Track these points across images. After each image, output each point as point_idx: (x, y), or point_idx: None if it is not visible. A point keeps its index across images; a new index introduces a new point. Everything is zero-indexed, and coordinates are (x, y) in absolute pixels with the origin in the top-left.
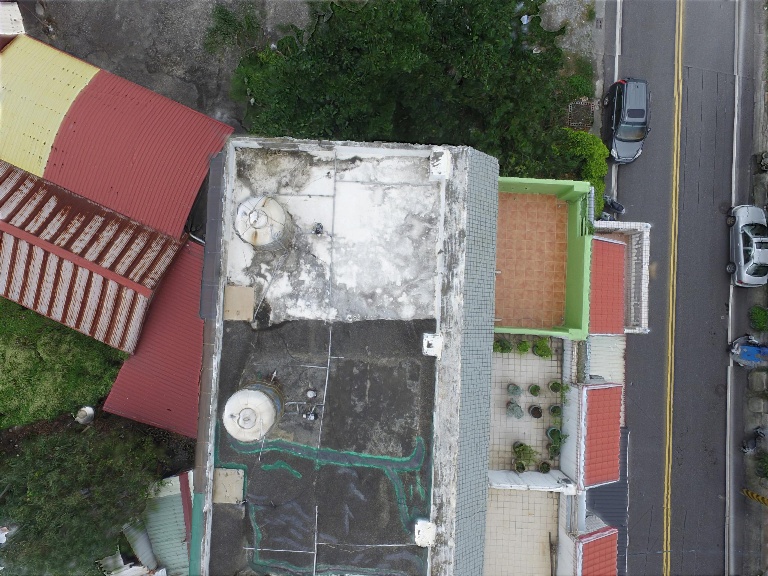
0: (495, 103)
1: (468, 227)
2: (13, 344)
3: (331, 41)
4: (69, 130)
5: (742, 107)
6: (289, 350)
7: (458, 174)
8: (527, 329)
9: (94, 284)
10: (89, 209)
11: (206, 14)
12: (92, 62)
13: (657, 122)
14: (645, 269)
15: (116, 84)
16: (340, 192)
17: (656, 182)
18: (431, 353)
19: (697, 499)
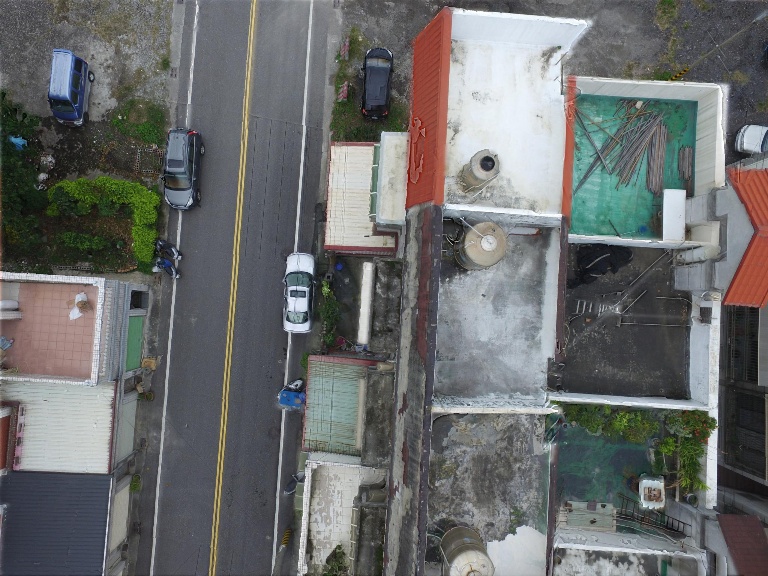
0: None
1: None
2: None
3: None
4: None
5: (309, 156)
6: None
7: None
8: None
9: None
10: None
11: None
12: None
13: (224, 170)
14: (97, 323)
15: None
16: None
17: (220, 228)
18: None
19: (245, 540)
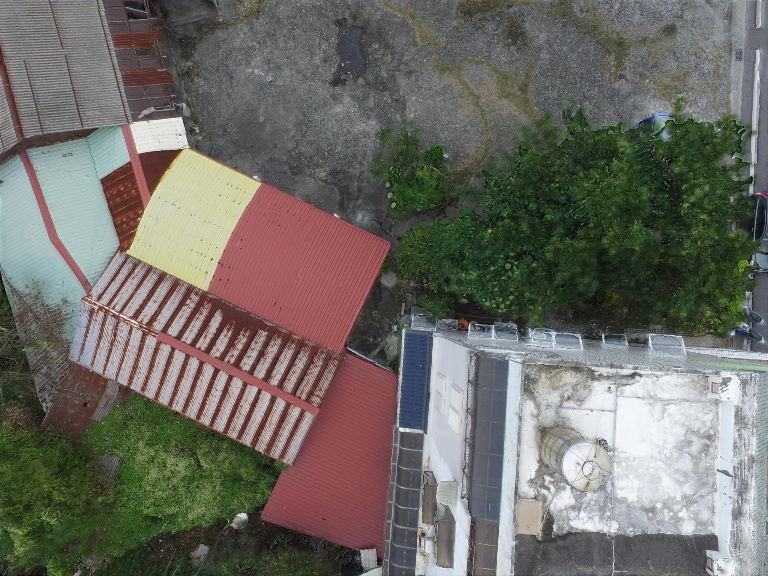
0: (697, 262)
1: (756, 452)
2: (173, 451)
3: (529, 193)
4: (236, 247)
5: None
6: (574, 563)
7: (747, 401)
8: (766, 517)
9: (261, 400)
10: (252, 323)
11: (348, 118)
12: (237, 163)
13: None
14: None
15: (278, 199)
16: (621, 407)
17: None
18: (721, 575)
19: None
